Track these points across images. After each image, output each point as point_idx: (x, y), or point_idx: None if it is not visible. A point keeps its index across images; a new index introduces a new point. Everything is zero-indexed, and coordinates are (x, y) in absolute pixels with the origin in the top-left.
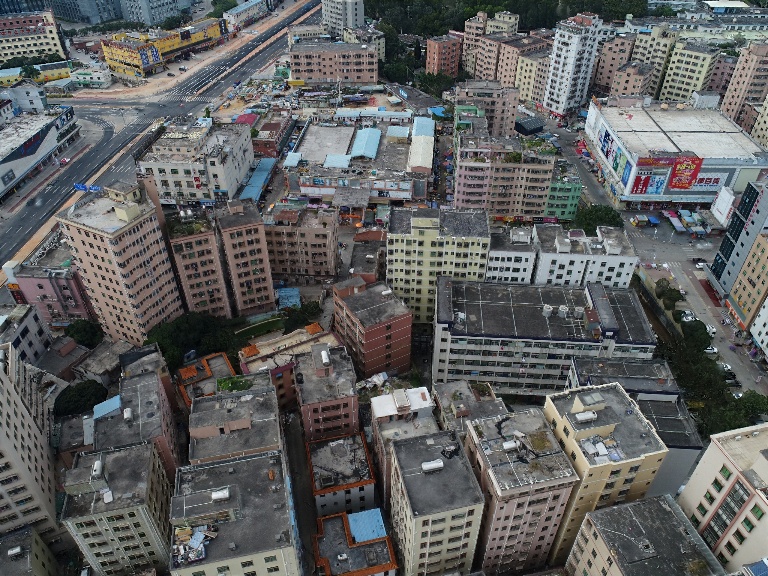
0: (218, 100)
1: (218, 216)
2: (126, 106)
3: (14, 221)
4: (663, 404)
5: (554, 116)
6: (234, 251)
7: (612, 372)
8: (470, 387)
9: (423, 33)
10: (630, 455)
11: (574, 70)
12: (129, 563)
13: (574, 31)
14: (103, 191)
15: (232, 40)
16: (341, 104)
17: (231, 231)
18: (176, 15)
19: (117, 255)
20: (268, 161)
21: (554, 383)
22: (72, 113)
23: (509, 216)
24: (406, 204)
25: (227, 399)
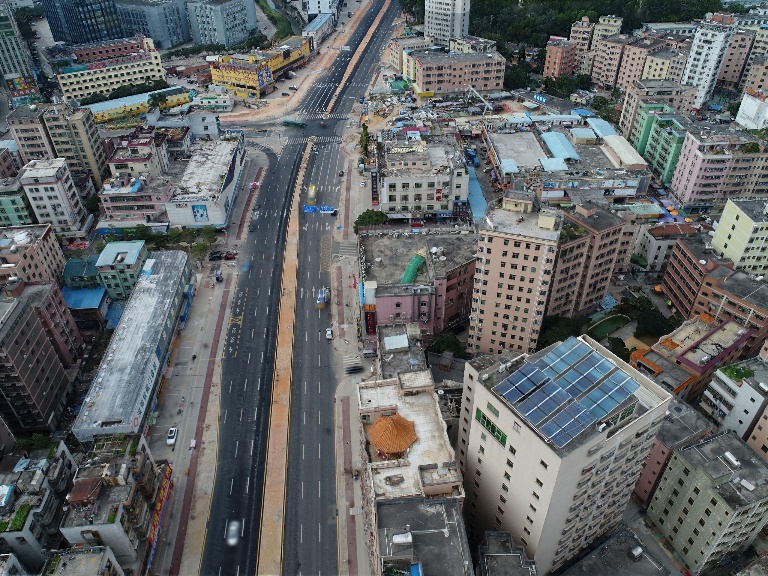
0: (354, 116)
1: (575, 220)
2: (267, 127)
3: (250, 248)
4: None
5: None
6: (598, 252)
7: None
8: None
9: (512, 40)
10: None
11: (715, 66)
12: (727, 551)
13: (719, 29)
14: (492, 203)
15: (318, 57)
16: (481, 112)
17: (603, 233)
18: (246, 35)
19: (549, 262)
20: (468, 170)
21: None
22: (243, 137)
23: None
24: (629, 201)
25: None
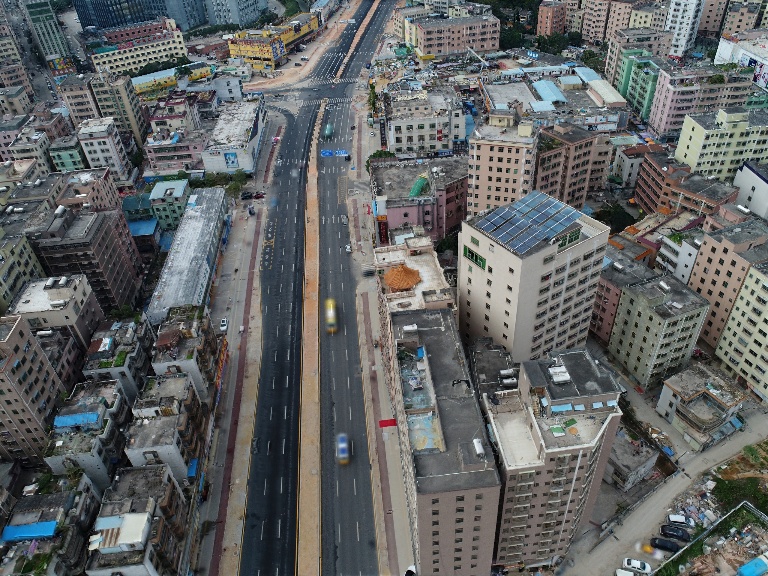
0: (362, 80)
1: (553, 137)
2: (283, 93)
3: (276, 189)
4: None
5: (672, 59)
6: (573, 163)
7: None
8: None
9: (508, 6)
10: None
11: (694, 15)
12: None
13: None
14: (481, 121)
15: (326, 31)
16: (478, 70)
17: (576, 144)
18: (258, 15)
19: (528, 163)
20: (466, 117)
21: None
22: None
23: None
24: (611, 135)
25: (725, 232)
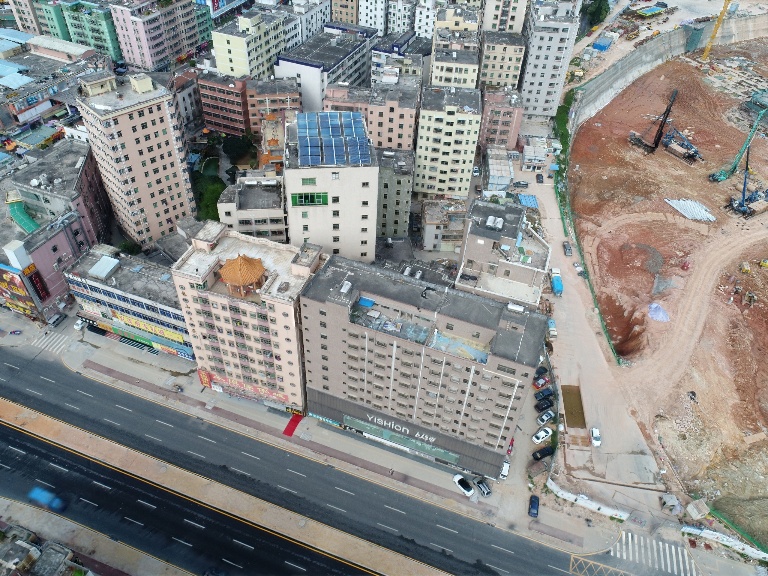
0: None
1: None
2: None
3: None
4: (415, 42)
5: None
6: None
7: (388, 45)
8: (393, 58)
9: None
10: (474, 19)
11: None
12: None
13: None
14: None
15: None
16: None
17: (168, 88)
18: None
19: (173, 117)
20: None
21: (357, 83)
22: None
23: (183, 54)
24: None
25: (372, 99)
